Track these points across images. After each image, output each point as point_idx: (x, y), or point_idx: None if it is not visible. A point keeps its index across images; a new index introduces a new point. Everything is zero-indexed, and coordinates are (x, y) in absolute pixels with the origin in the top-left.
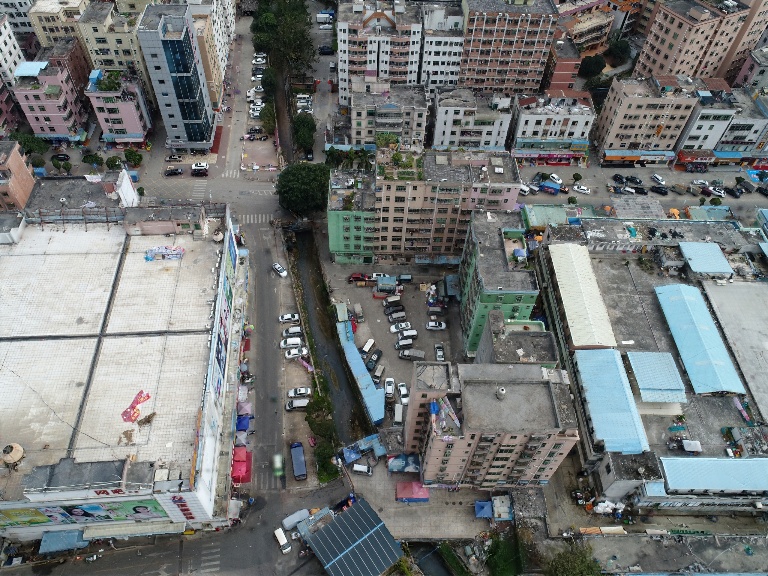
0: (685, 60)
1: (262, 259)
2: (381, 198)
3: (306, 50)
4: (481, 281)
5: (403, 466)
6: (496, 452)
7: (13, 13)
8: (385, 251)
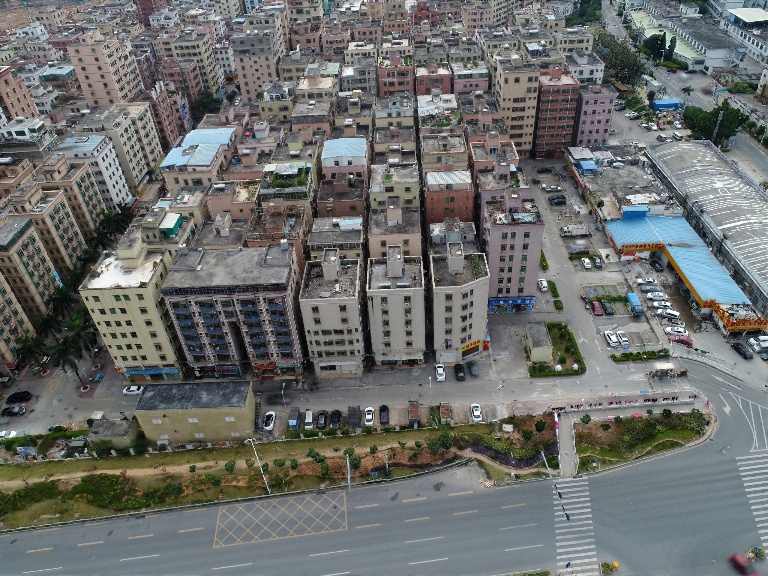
0: None
1: None
2: None
3: None
4: None
5: None
6: None
7: None
8: None
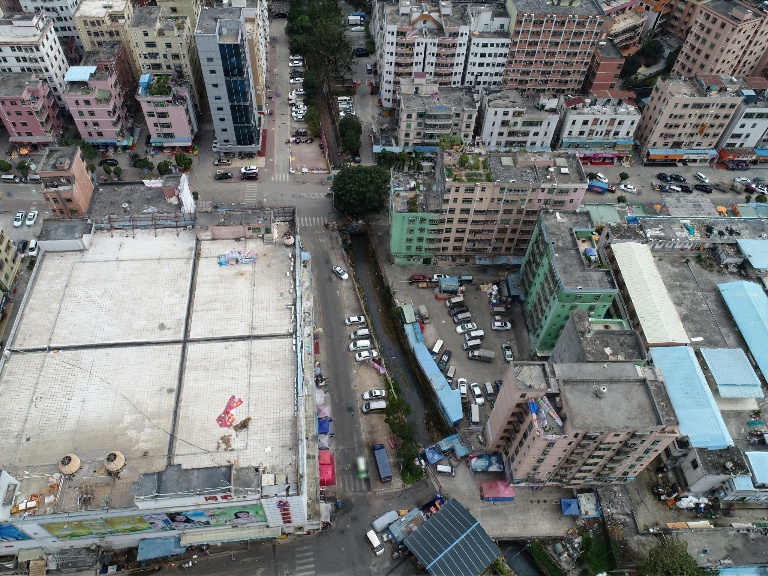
0: (726, 59)
1: (321, 262)
2: (449, 200)
3: (344, 52)
4: (559, 281)
5: (487, 466)
6: (594, 450)
7: (54, 17)
8: (446, 252)
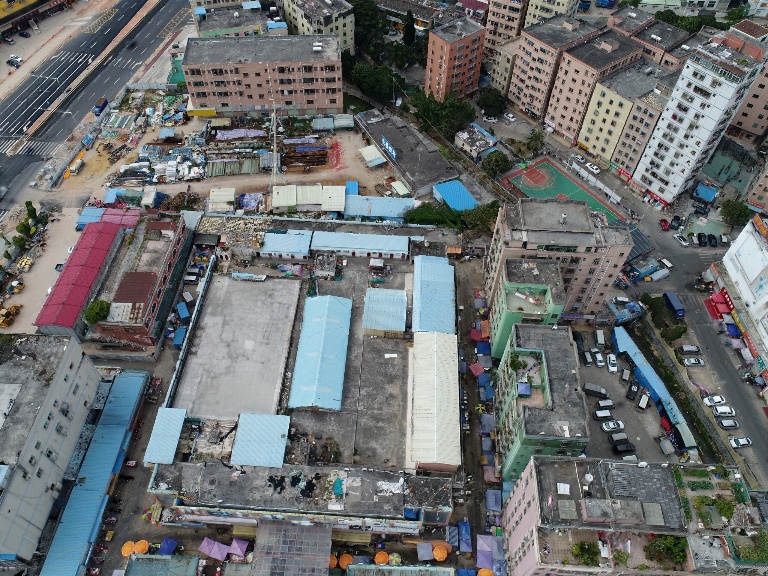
0: None
1: None
2: None
3: None
4: None
5: None
6: None
7: None
8: None
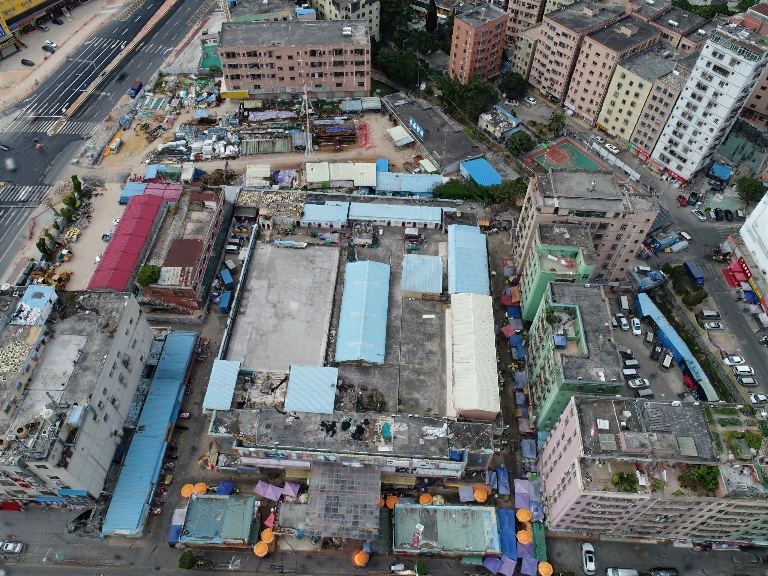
0: None
1: None
2: None
3: None
4: None
5: None
6: None
7: None
8: None
